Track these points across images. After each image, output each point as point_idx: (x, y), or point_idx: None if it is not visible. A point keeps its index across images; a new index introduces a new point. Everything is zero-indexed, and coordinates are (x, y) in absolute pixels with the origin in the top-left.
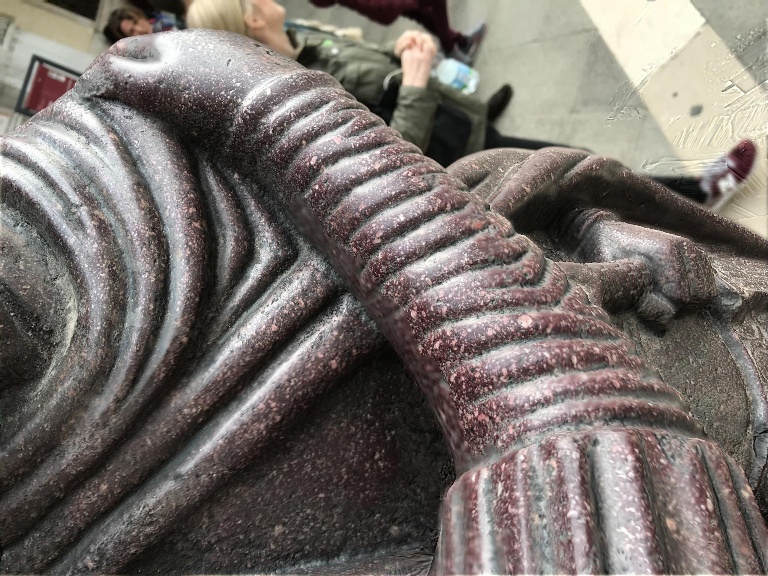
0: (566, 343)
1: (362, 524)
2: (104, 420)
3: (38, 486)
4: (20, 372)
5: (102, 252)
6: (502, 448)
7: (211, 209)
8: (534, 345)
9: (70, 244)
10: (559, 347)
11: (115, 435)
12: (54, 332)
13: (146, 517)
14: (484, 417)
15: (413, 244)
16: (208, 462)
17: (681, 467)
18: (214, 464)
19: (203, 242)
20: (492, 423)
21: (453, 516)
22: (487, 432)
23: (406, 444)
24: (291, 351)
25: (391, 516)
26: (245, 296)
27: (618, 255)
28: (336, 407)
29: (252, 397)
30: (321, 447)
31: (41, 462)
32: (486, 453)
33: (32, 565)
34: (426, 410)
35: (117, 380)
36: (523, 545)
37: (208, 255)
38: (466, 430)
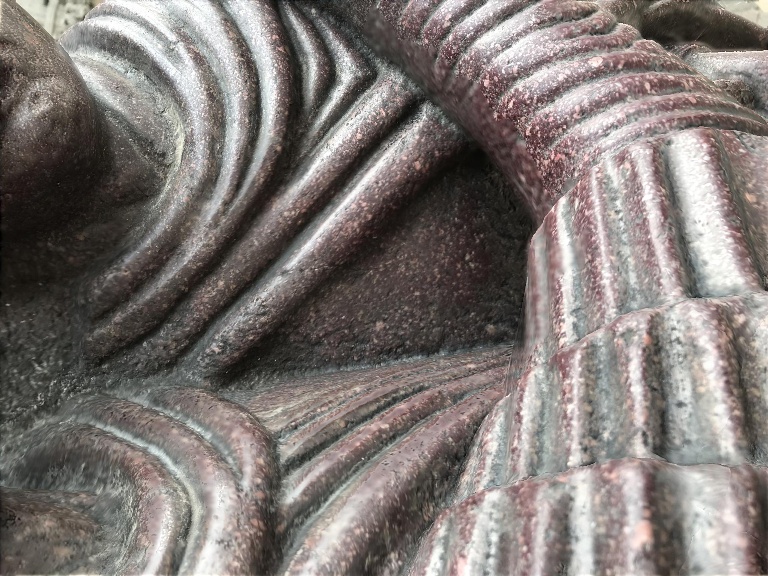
0: (639, 75)
1: (458, 321)
2: (215, 221)
3: (166, 280)
4: (142, 189)
5: (200, 78)
6: (579, 177)
7: (293, 42)
8: (606, 80)
9: (172, 75)
10: (631, 77)
11: (226, 234)
12: (166, 155)
13: (260, 307)
14: (560, 156)
15: (481, 17)
16: (309, 258)
17: (762, 152)
18: (315, 259)
19: (287, 64)
20: (568, 159)
21: (536, 253)
22: (564, 170)
23: (495, 248)
24: (377, 158)
25: (486, 315)
26: (330, 113)
27: (714, 80)
28: (424, 211)
29: (344, 200)
30: (413, 249)
31: (167, 260)
32: (565, 190)
33: (168, 351)
34: (513, 217)
35: (223, 186)
36: (600, 234)
37: (293, 76)
38: (544, 178)
